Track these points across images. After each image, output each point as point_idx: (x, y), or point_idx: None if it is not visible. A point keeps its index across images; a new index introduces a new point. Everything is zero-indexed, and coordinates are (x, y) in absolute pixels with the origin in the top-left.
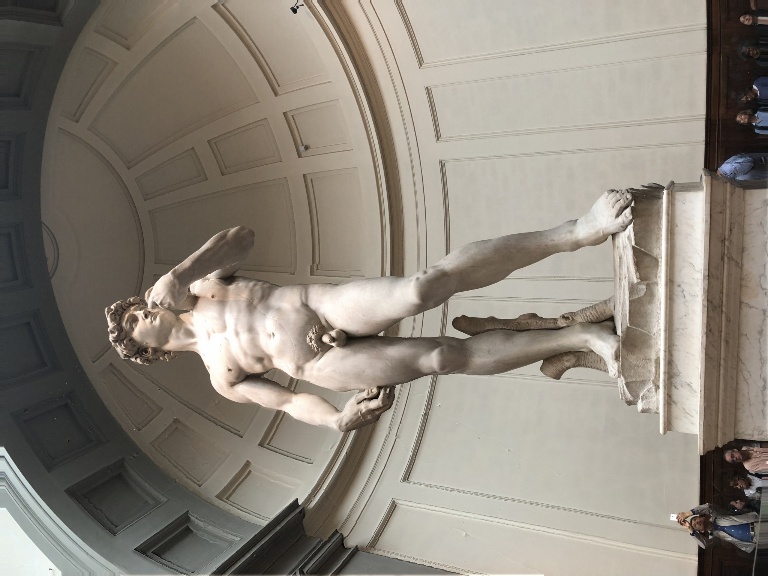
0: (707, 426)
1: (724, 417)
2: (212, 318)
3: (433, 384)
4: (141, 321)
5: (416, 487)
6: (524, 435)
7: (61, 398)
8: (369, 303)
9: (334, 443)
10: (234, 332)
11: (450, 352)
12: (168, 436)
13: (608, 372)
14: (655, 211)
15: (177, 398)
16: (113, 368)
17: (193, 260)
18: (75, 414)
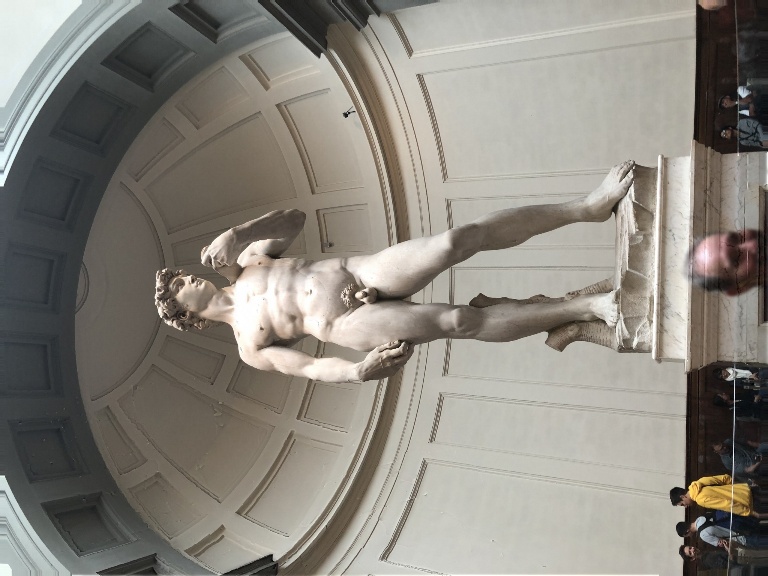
0: (694, 346)
1: (708, 339)
2: (255, 281)
3: (421, 474)
4: (187, 285)
5: (395, 566)
6: (509, 528)
7: (55, 422)
8: (405, 254)
9: (314, 517)
10: (274, 291)
11: (469, 311)
12: (147, 488)
13: (608, 322)
14: (651, 174)
15: (163, 454)
16: (109, 411)
17: (252, 223)
18: (64, 440)
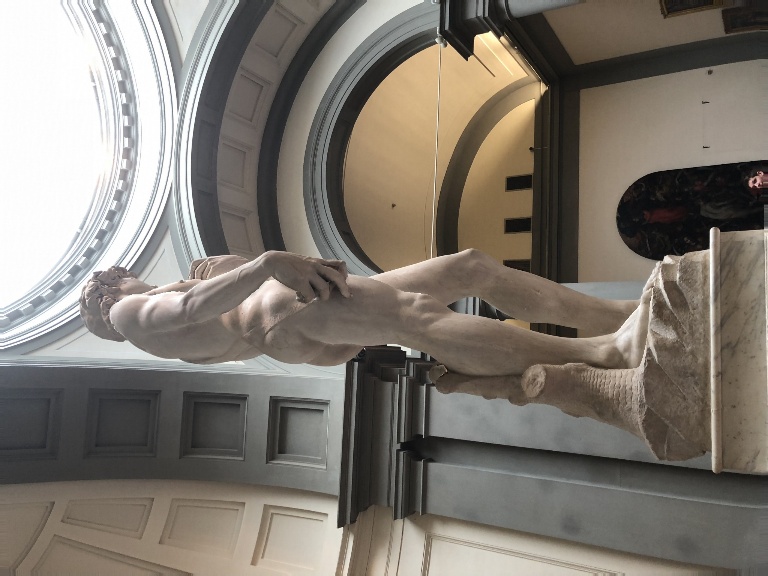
0: None
1: None
2: None
3: None
4: None
5: None
6: None
7: None
8: None
9: None
10: None
11: None
12: None
13: None
14: None
15: None
16: None
17: None
18: None
